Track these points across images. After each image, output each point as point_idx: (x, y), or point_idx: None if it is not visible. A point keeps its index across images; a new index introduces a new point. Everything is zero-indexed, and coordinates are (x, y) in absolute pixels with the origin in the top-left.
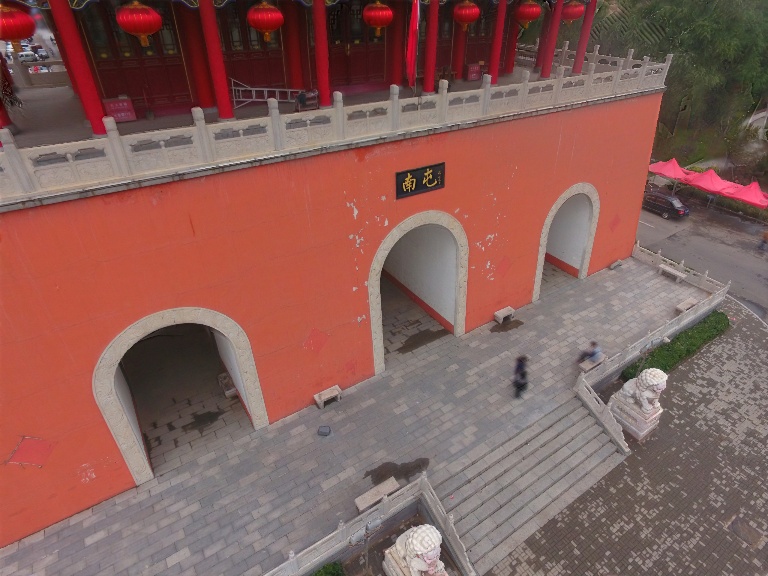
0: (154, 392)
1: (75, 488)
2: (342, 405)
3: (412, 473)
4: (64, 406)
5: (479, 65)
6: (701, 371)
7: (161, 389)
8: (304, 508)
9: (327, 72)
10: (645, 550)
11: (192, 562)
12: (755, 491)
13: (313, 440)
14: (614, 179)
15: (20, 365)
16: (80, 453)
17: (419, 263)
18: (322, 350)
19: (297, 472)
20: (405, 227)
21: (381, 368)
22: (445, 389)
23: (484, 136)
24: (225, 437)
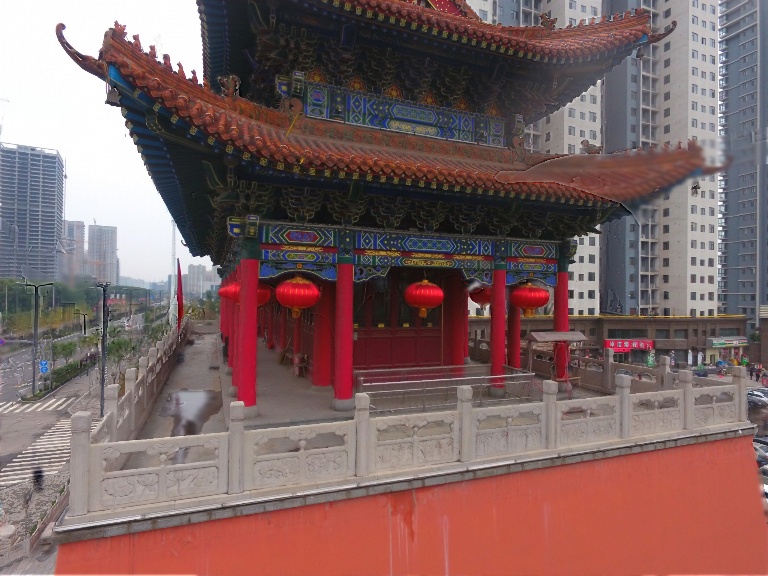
0: None
1: None
2: None
3: (45, 553)
4: None
5: (301, 358)
6: None
7: None
8: None
9: (225, 322)
10: None
11: None
12: None
13: None
14: None
15: None
16: None
17: None
18: None
19: None
20: None
21: None
22: None
23: None
24: None
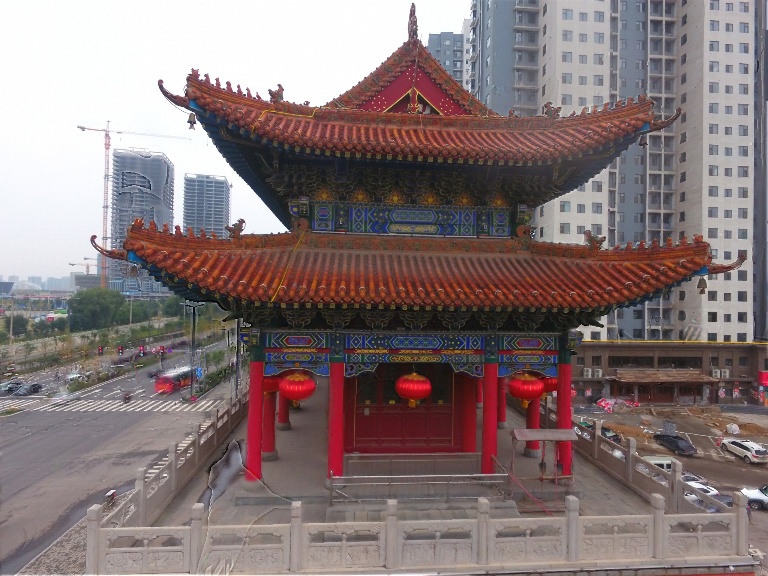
0: None
1: None
2: None
3: None
4: None
5: None
6: None
7: None
8: None
9: None
10: None
11: None
12: None
13: None
14: None
15: None
16: None
17: None
18: None
19: None
20: None
21: None
22: None
23: None
24: None
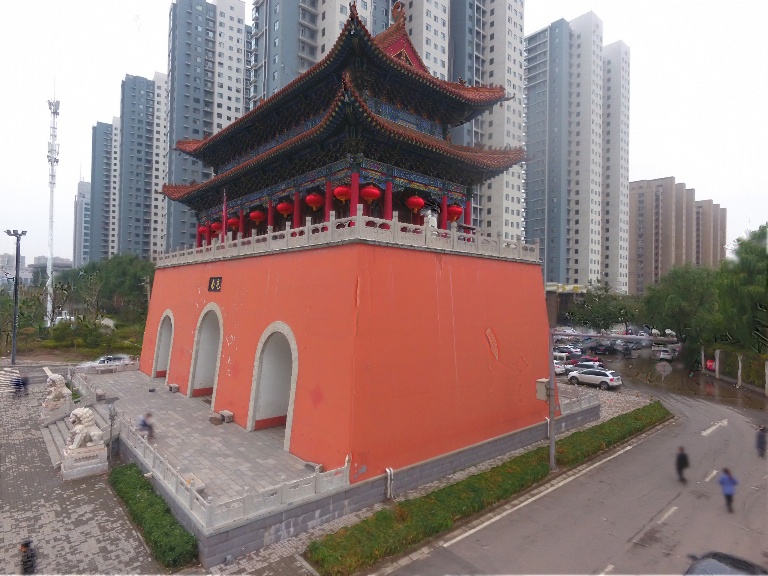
0: None
1: None
2: None
3: (107, 402)
4: None
5: None
6: (102, 520)
7: None
8: None
9: None
10: None
11: None
12: None
13: None
14: (312, 333)
15: None
16: None
17: None
18: None
19: None
20: None
21: None
22: None
23: (235, 266)
24: None
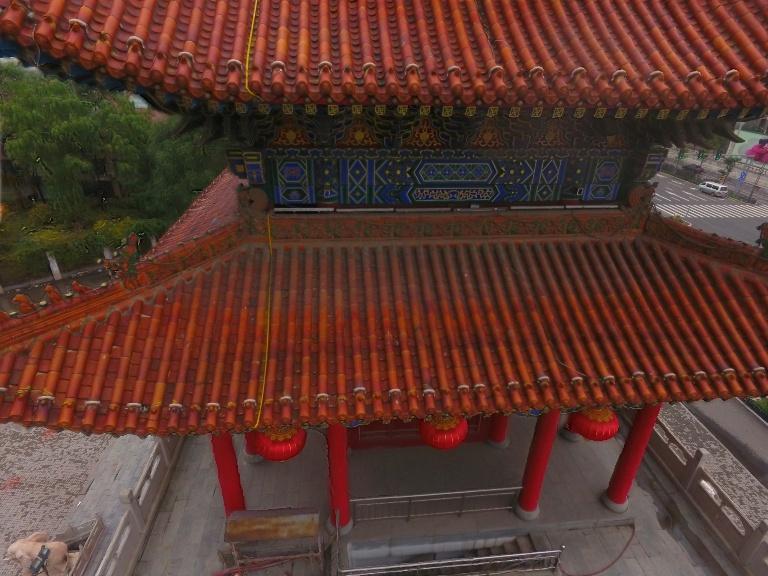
0: None
1: None
2: None
3: None
4: None
5: None
6: None
7: None
8: None
9: None
10: None
11: None
12: None
13: None
14: None
15: None
16: None
17: None
18: None
19: None
20: None
21: None
22: None
23: None
24: None
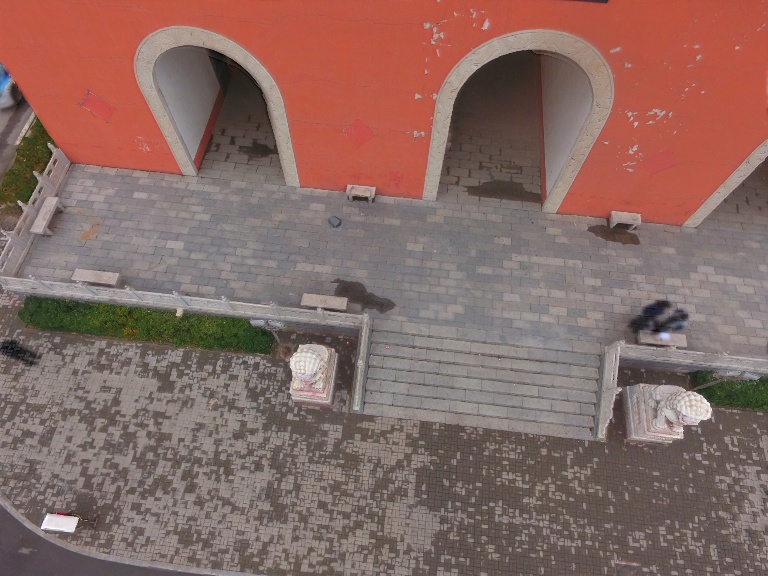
0: (241, 101)
1: (136, 151)
2: (369, 209)
3: (371, 306)
4: (116, 80)
5: None
6: None
7: (247, 101)
8: (272, 272)
9: None
10: (514, 510)
11: (180, 254)
12: (693, 570)
13: (321, 223)
14: None
15: (72, 25)
16: (135, 126)
17: (563, 98)
18: (364, 146)
19: (289, 241)
20: (514, 43)
21: (431, 196)
22: (473, 256)
23: None
24: (262, 176)
